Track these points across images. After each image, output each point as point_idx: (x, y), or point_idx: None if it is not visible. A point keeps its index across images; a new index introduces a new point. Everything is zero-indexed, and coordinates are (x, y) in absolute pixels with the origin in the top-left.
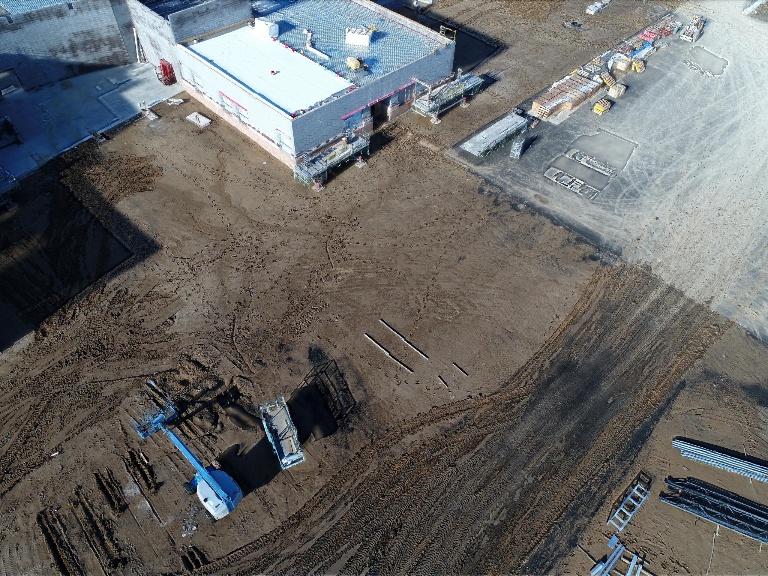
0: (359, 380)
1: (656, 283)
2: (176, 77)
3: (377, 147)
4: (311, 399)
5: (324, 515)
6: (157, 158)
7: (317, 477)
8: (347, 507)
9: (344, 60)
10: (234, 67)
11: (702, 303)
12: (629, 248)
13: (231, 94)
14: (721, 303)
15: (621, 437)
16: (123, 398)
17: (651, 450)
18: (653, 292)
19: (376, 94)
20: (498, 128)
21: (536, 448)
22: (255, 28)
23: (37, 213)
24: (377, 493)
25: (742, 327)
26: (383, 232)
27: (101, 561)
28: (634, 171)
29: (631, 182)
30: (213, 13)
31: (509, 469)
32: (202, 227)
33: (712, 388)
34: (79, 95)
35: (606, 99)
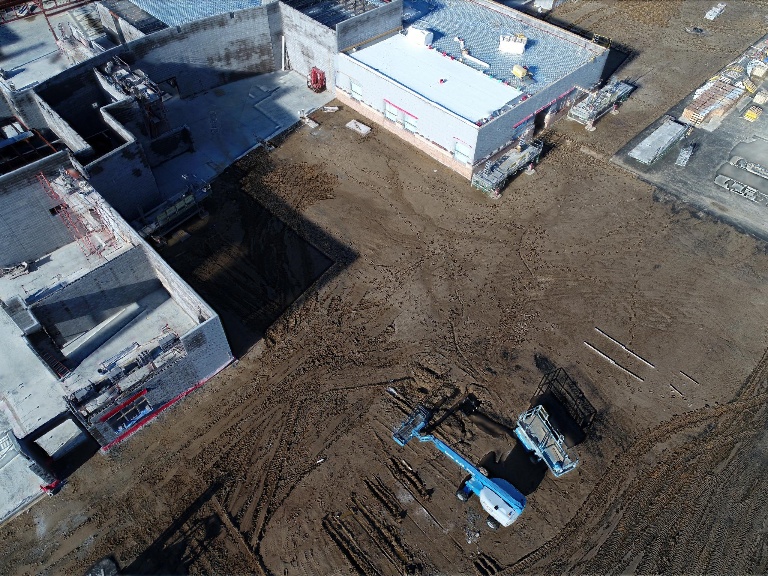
0: (593, 388)
1: None
2: (327, 85)
3: (541, 154)
4: (551, 407)
5: (599, 522)
6: (329, 166)
7: (581, 485)
8: (619, 515)
9: (504, 68)
10: (401, 75)
11: None
12: None
13: (400, 102)
14: None
15: None
16: (369, 405)
17: None
18: None
19: (542, 102)
20: (660, 135)
21: None
22: (407, 36)
23: (229, 221)
24: (644, 501)
25: None
26: (571, 240)
27: (397, 567)
28: None
29: None
30: (372, 22)
31: (767, 478)
32: (393, 235)
33: None
34: (235, 103)
35: None
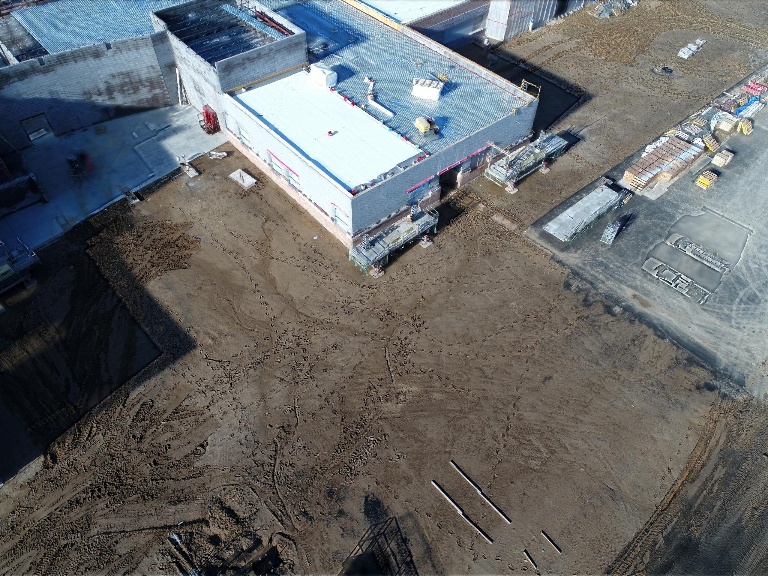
0: (426, 549)
1: None
2: (220, 125)
3: (444, 221)
4: (367, 574)
5: None
6: (195, 226)
7: None
8: None
9: (411, 118)
10: (286, 124)
11: None
12: (753, 376)
13: (281, 156)
14: None
15: None
16: (140, 558)
17: None
18: None
19: (447, 162)
20: (586, 205)
21: None
22: (310, 74)
23: (58, 293)
24: None
25: None
26: (453, 336)
27: None
28: (751, 267)
29: (748, 282)
30: (265, 58)
31: None
32: (242, 320)
33: None
34: (113, 143)
35: (710, 168)
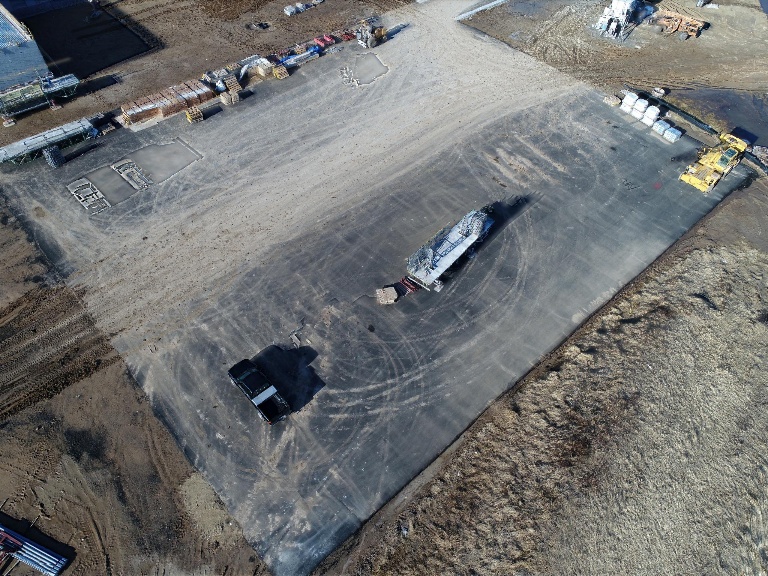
0: None
1: (75, 310)
2: None
3: None
4: None
5: None
6: None
7: None
8: None
9: None
10: None
11: (105, 335)
12: (82, 270)
13: None
14: (127, 336)
15: None
16: None
17: None
18: (63, 320)
19: None
20: (51, 134)
21: None
22: None
23: None
24: None
25: (126, 364)
26: None
27: None
28: (170, 185)
29: (155, 197)
30: None
31: None
32: None
33: (32, 432)
34: None
35: (215, 106)
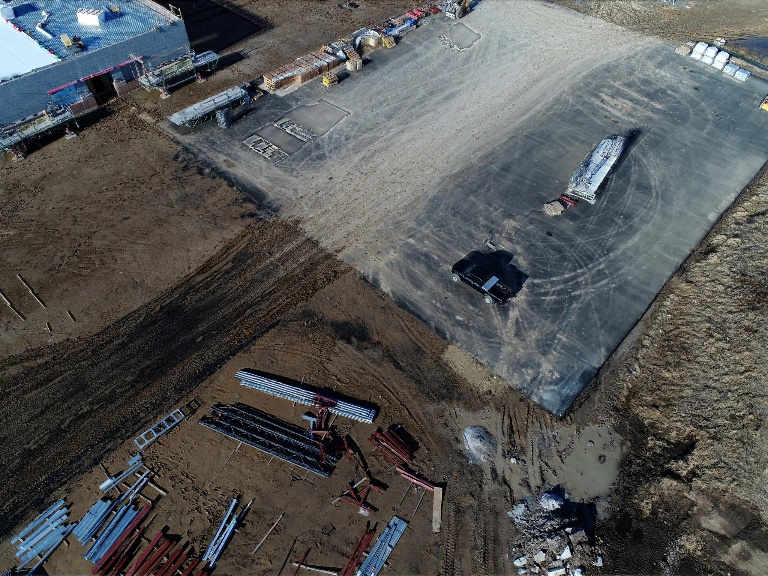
0: None
1: (297, 236)
2: None
3: (95, 120)
4: None
5: None
6: None
7: None
8: None
9: None
10: None
11: (331, 252)
12: (288, 205)
13: None
14: (350, 252)
15: (192, 370)
16: None
17: (214, 381)
18: (290, 244)
19: (88, 69)
20: None
21: (106, 382)
22: None
23: None
24: None
25: (358, 272)
26: (62, 197)
27: None
28: (333, 137)
29: (324, 147)
30: None
31: (71, 401)
32: None
33: (302, 326)
34: None
35: (343, 72)
